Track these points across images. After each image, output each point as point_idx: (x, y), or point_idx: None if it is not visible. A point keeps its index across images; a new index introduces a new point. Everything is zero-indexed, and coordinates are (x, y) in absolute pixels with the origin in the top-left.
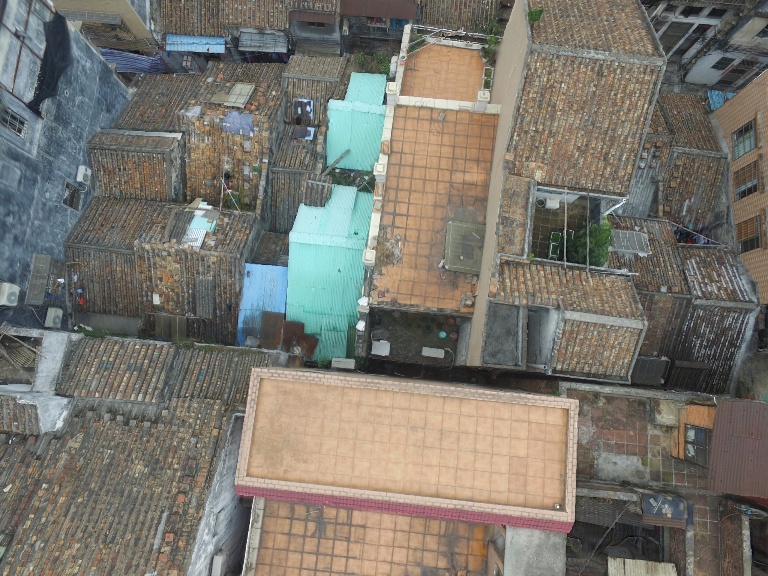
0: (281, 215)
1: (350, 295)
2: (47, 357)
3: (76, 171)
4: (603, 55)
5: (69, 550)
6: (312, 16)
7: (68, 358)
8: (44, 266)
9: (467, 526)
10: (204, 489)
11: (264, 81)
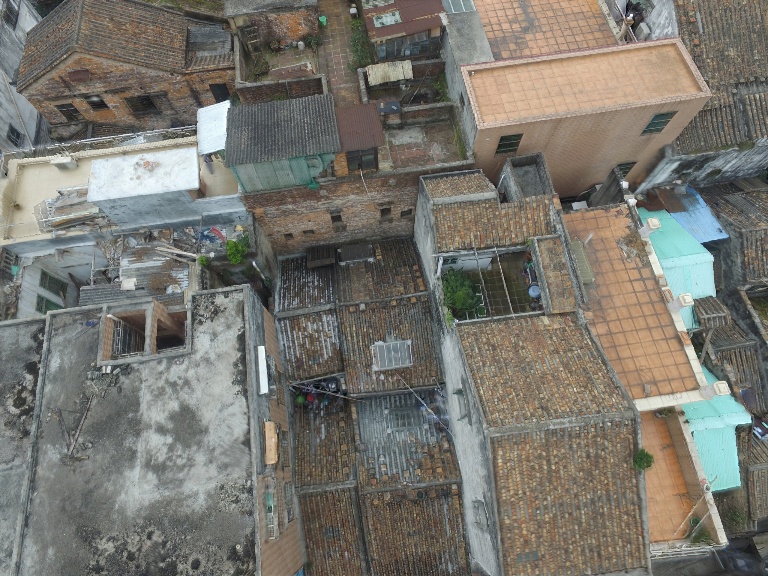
0: None
1: None
2: None
3: None
4: (555, 423)
5: None
6: None
7: None
8: None
9: None
10: None
11: None
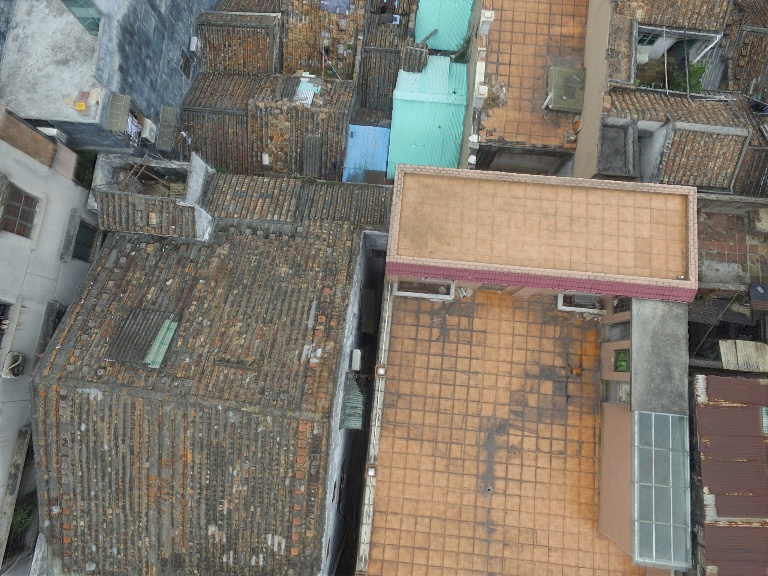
0: (371, 94)
1: (449, 151)
2: (193, 176)
3: (188, 42)
4: None
5: (233, 327)
6: None
7: (205, 187)
8: (171, 117)
9: (580, 330)
10: (346, 285)
11: None
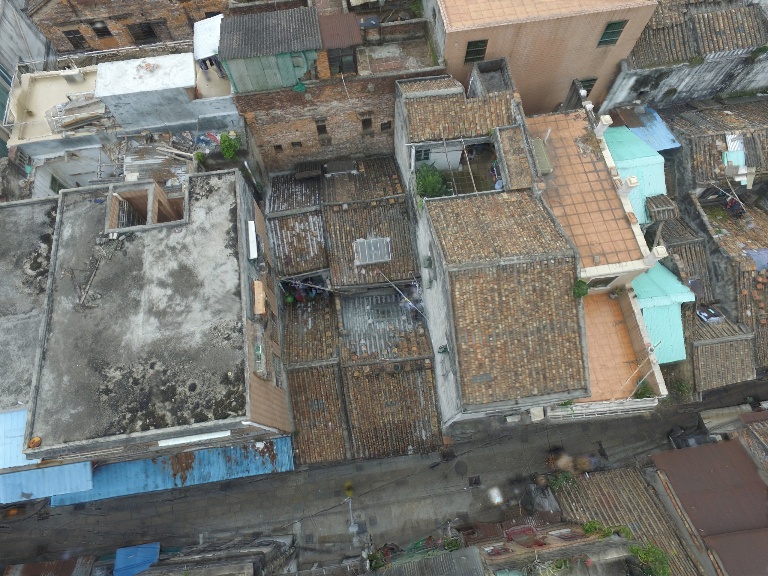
0: None
1: None
2: None
3: None
4: (505, 260)
5: None
6: (767, 416)
7: (767, 26)
8: None
9: None
10: None
11: (765, 330)
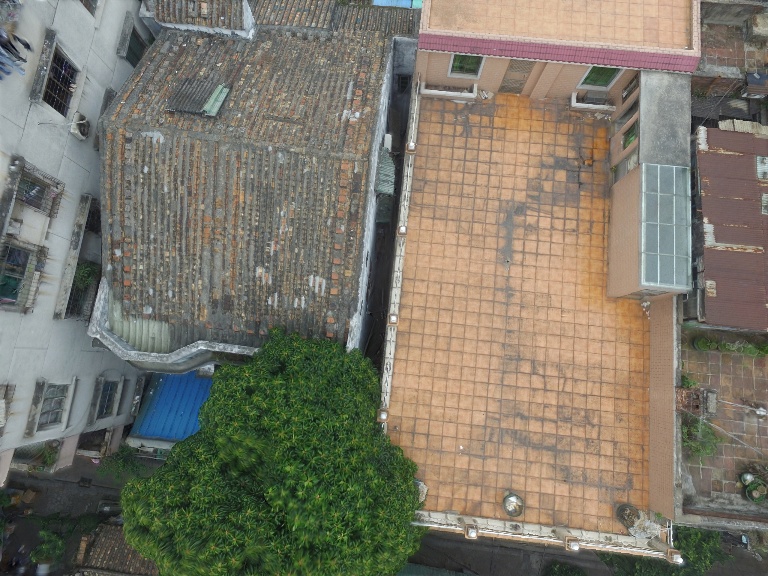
0: None
1: None
2: None
3: None
4: None
5: (279, 96)
6: None
7: (248, 0)
8: None
9: (591, 128)
10: (380, 72)
11: None
